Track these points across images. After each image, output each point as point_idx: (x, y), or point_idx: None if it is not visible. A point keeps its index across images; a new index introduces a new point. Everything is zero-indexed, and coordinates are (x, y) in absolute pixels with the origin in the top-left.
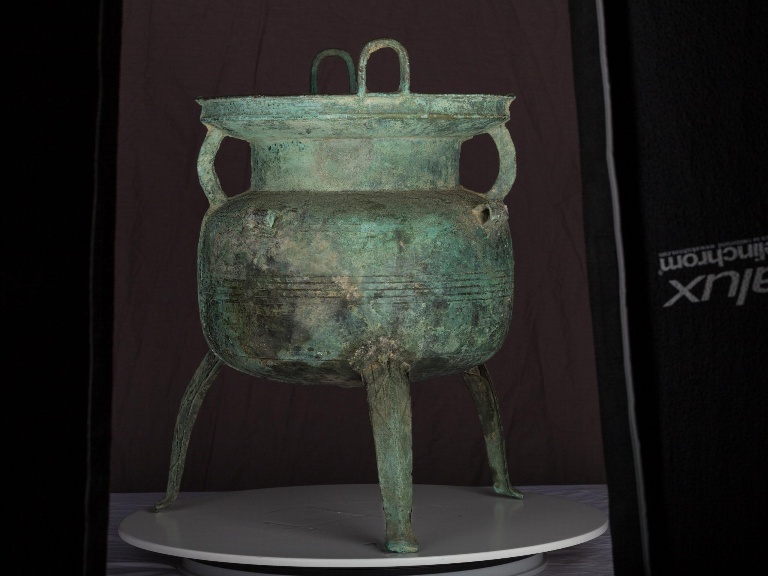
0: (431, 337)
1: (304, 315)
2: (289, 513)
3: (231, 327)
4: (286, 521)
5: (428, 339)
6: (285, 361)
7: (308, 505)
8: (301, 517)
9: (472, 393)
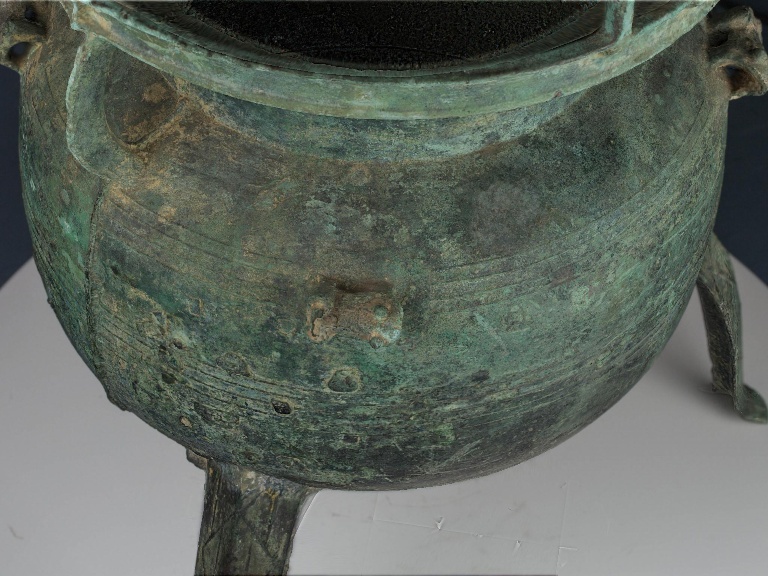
0: None
1: None
2: (520, 482)
3: (478, 3)
4: None
5: None
6: (356, 51)
7: (549, 567)
8: None
9: None
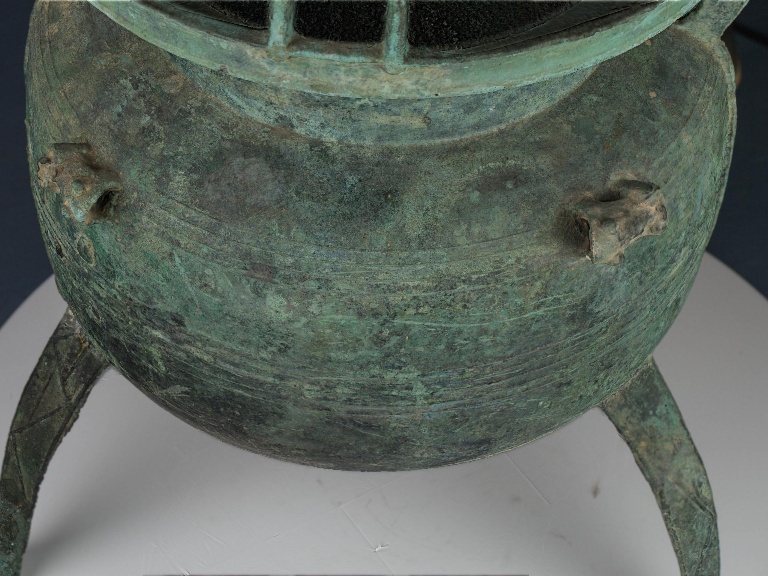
0: (315, 4)
1: (554, 2)
2: (477, 569)
3: None
4: (505, 491)
5: (321, 7)
6: None
7: None
8: (466, 523)
9: (58, 439)
